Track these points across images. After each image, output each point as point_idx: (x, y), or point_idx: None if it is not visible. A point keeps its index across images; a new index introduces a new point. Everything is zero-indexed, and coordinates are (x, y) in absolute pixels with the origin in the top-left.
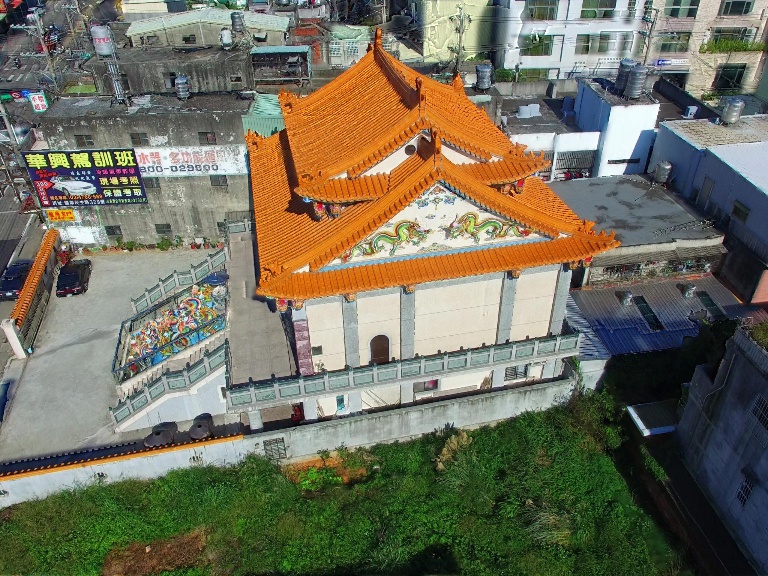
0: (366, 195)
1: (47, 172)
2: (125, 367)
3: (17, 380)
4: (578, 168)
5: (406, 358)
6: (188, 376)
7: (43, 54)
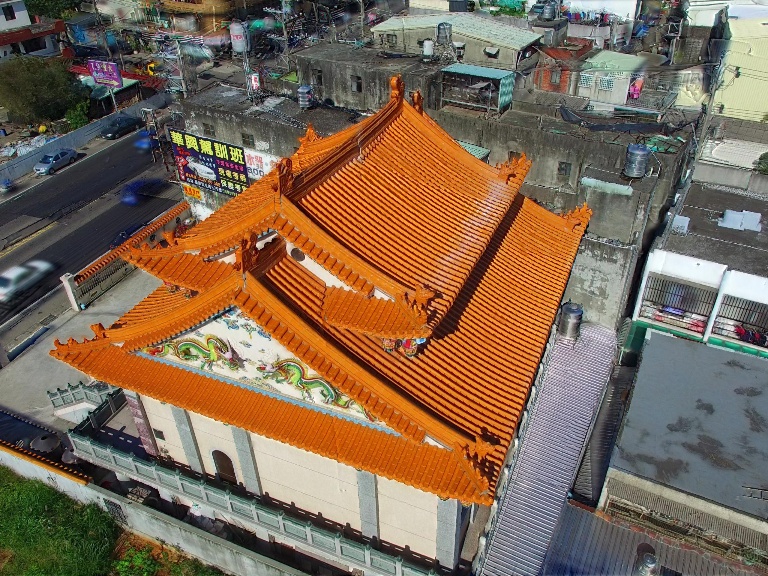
0: (198, 287)
1: (184, 150)
2: None
3: (55, 329)
4: (760, 326)
5: (251, 491)
6: (100, 395)
7: (283, 38)
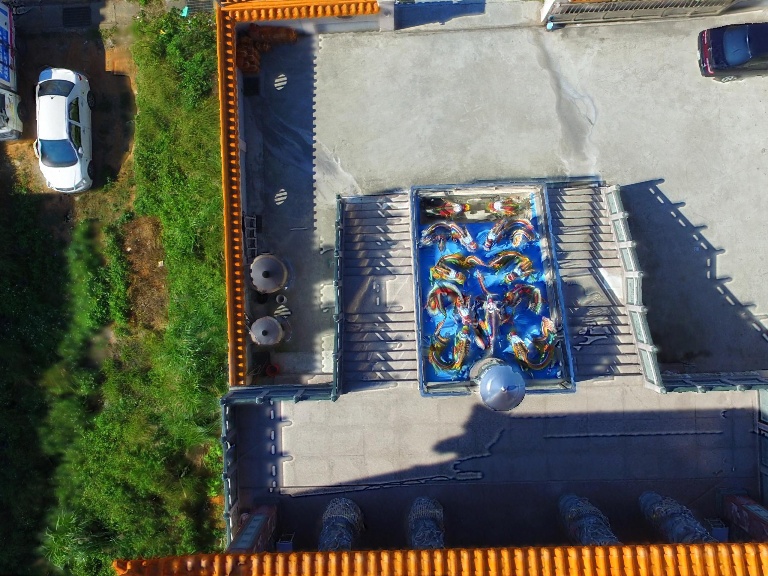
0: None
1: None
2: (413, 208)
3: (487, 23)
4: None
5: None
6: None
7: None
